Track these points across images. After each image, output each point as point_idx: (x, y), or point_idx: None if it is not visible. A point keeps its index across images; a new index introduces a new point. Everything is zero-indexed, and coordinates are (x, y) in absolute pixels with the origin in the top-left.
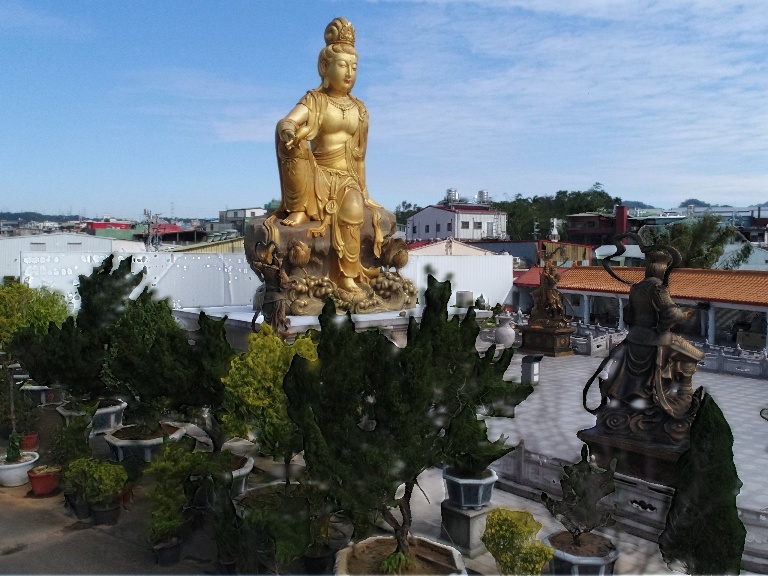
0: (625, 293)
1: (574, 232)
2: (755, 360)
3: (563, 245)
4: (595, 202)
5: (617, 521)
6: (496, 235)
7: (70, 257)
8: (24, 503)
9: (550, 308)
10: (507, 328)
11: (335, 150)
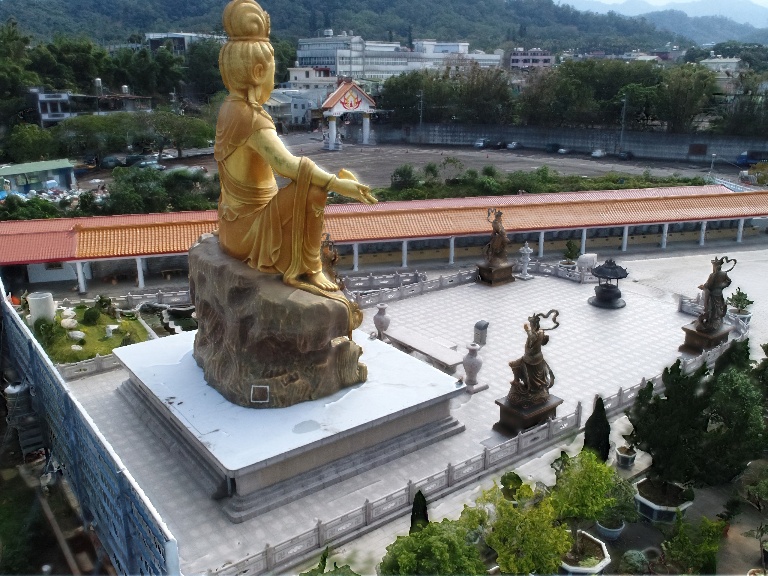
0: None
1: None
2: None
3: None
4: None
5: None
6: None
7: None
8: None
9: None
10: None
11: None
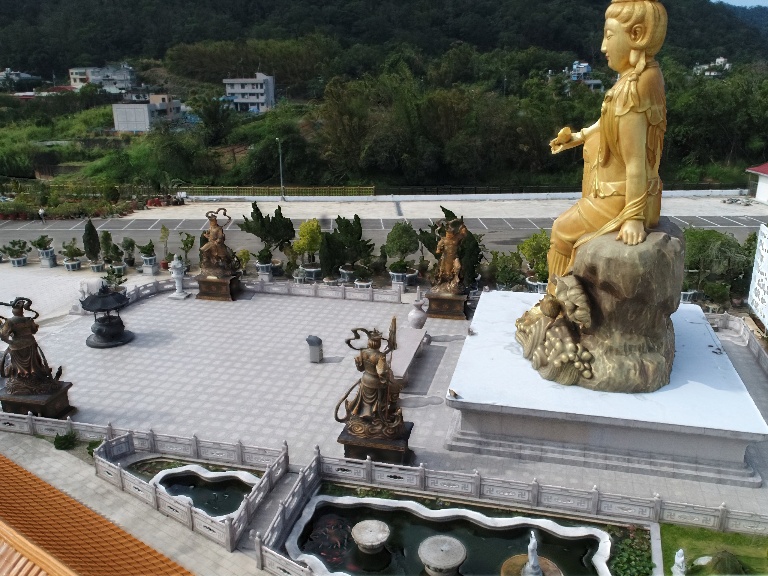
0: None
1: None
2: None
3: None
4: None
5: None
6: None
7: None
8: None
9: None
10: None
11: None
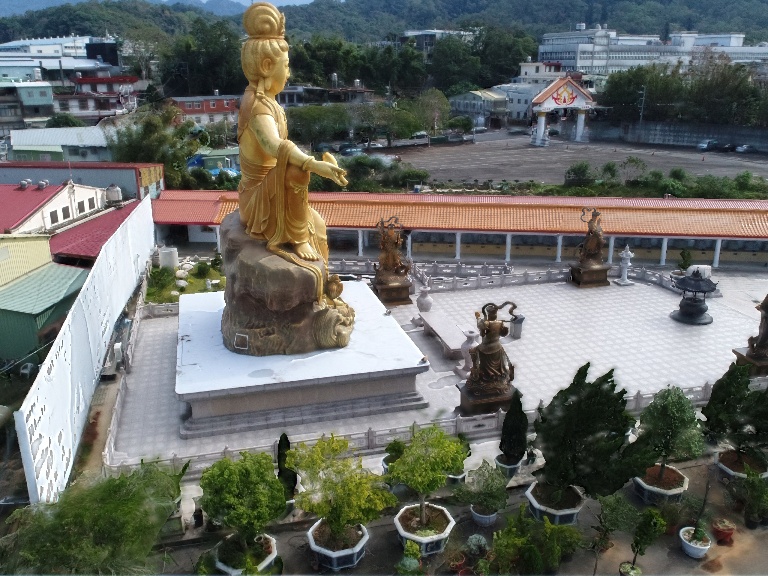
0: (327, 226)
1: None
2: (522, 274)
3: (149, 168)
4: None
5: None
6: None
7: (42, 387)
8: (744, 546)
9: None
10: (430, 297)
11: None
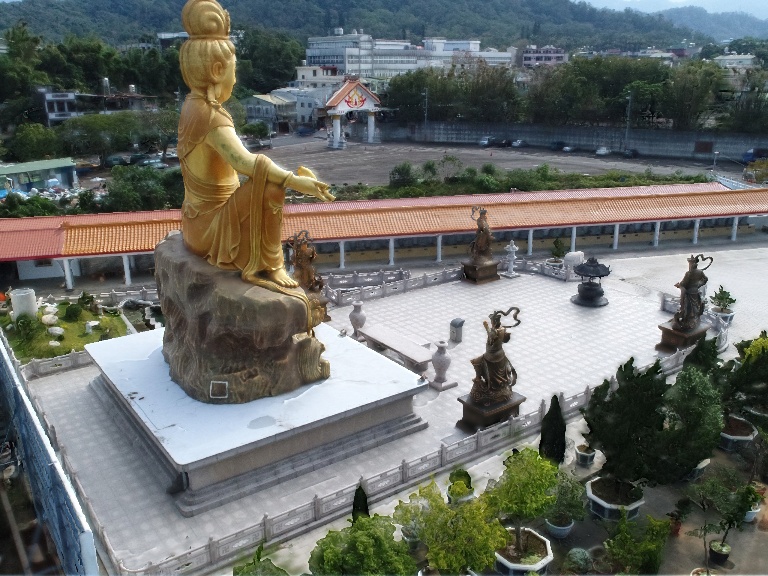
0: None
1: None
2: None
3: None
4: None
5: None
6: None
7: None
8: None
9: None
10: (363, 311)
11: None
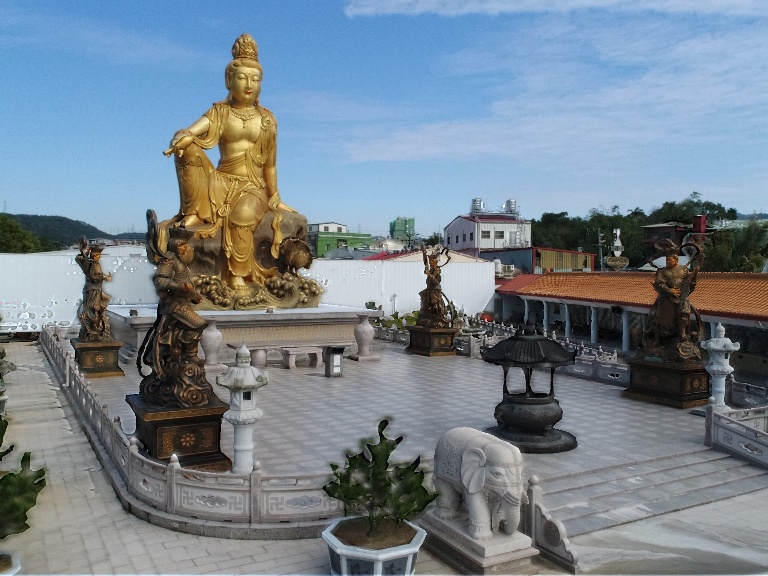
0: (564, 298)
1: (649, 244)
2: (588, 360)
3: (560, 252)
4: (690, 213)
5: (110, 474)
6: (520, 244)
7: (19, 258)
8: None
9: (432, 308)
10: (364, 325)
11: (235, 157)
